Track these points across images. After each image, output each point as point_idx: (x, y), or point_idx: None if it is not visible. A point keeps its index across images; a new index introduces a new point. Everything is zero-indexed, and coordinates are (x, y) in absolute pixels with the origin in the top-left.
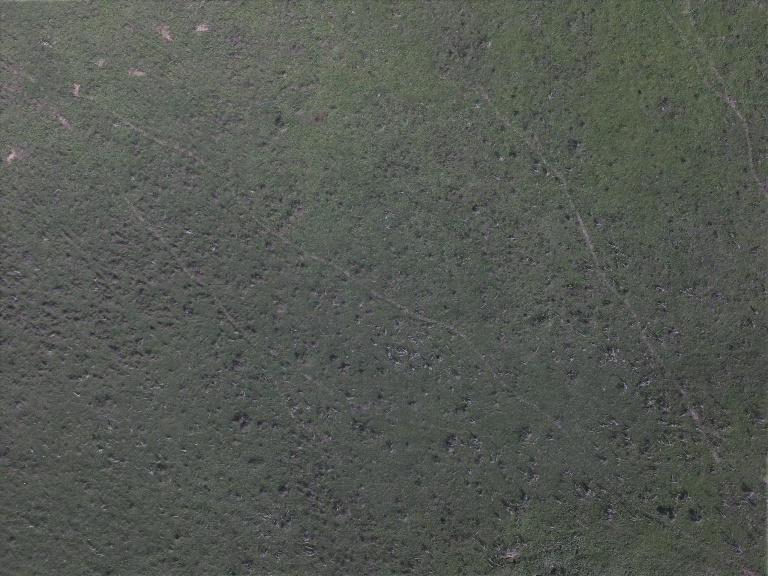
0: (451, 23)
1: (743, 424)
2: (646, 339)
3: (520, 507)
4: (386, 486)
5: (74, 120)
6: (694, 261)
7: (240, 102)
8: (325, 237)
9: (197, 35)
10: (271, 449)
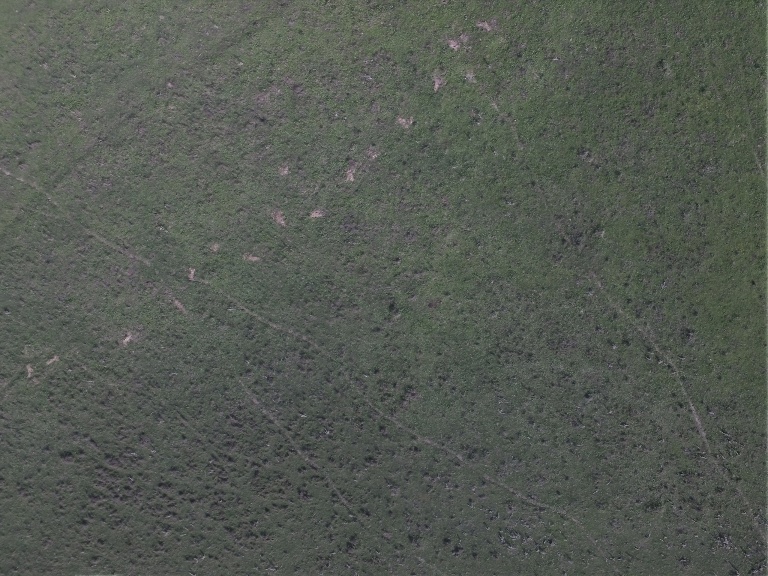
0: (564, 211)
1: None
2: (758, 526)
3: None
4: None
5: (189, 304)
6: None
7: (354, 288)
8: (438, 421)
9: (311, 221)
10: None
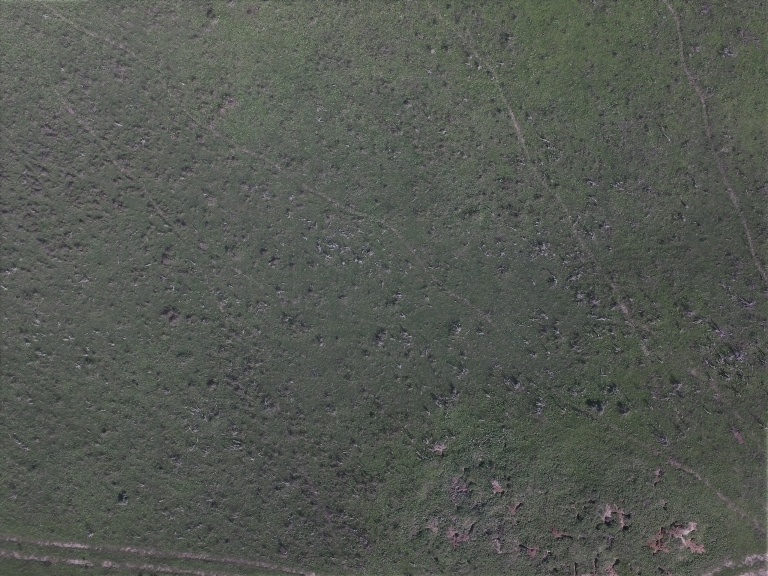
0: None
1: (672, 317)
2: (577, 233)
3: (449, 401)
4: (315, 380)
5: (4, 11)
6: (625, 155)
7: None
8: (256, 130)
9: None
10: (200, 343)
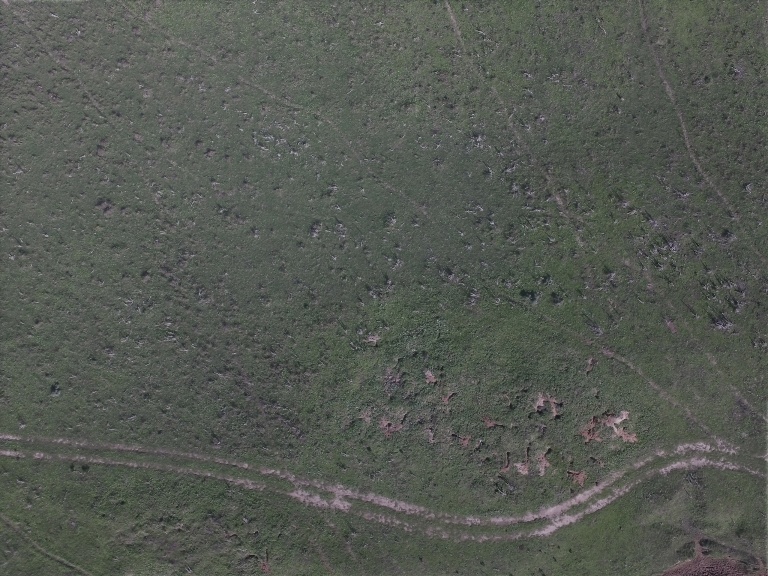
0: None
1: (607, 208)
2: (513, 126)
3: (383, 292)
4: (250, 272)
5: None
6: (561, 47)
7: None
8: (192, 22)
9: None
10: (134, 235)
